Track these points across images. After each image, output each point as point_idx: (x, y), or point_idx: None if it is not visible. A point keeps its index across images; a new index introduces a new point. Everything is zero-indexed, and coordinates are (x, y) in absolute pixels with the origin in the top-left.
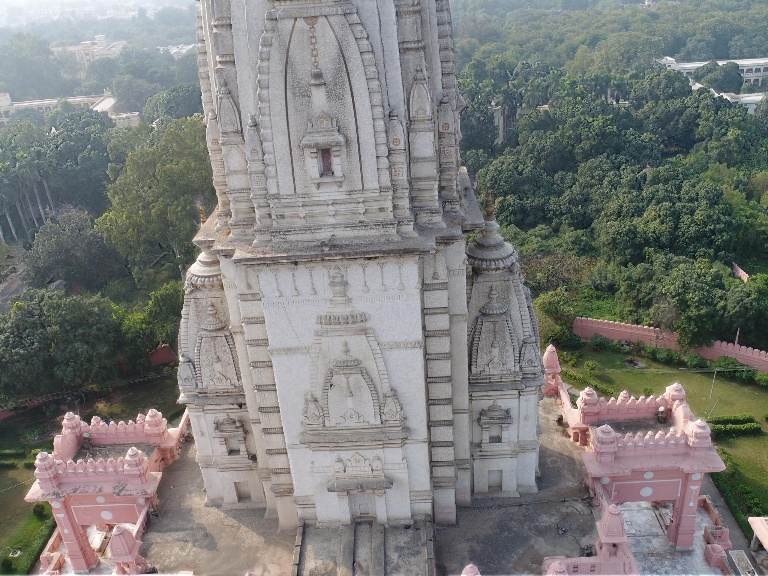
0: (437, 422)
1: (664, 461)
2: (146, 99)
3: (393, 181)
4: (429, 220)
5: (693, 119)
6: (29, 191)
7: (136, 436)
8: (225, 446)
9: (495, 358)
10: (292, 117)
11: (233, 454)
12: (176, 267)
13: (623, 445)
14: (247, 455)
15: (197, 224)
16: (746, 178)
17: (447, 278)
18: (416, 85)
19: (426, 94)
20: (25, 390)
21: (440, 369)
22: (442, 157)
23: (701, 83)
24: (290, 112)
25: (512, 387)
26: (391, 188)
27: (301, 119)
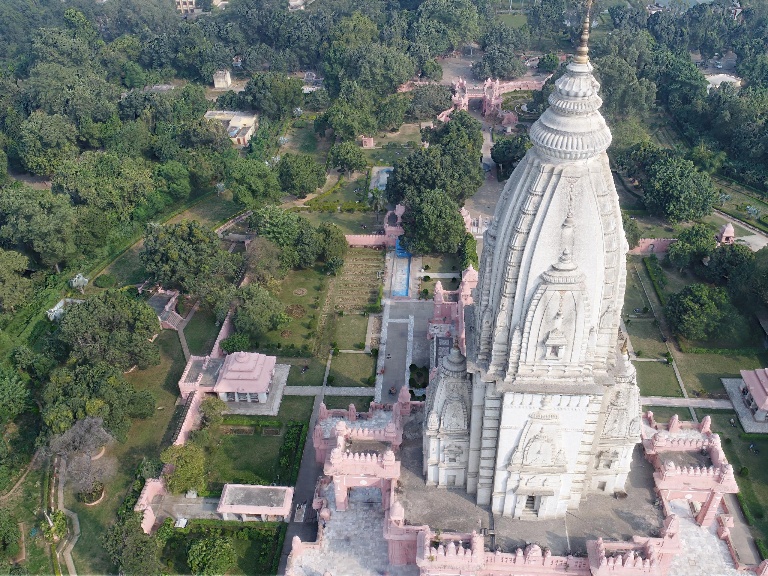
0: None
1: None
2: None
3: None
4: None
5: None
6: None
7: None
8: None
9: None
10: None
11: None
12: None
13: None
14: None
15: None
16: None
17: None
18: None
19: None
20: None
21: None
22: None
23: None
24: None
25: None
26: None
27: None
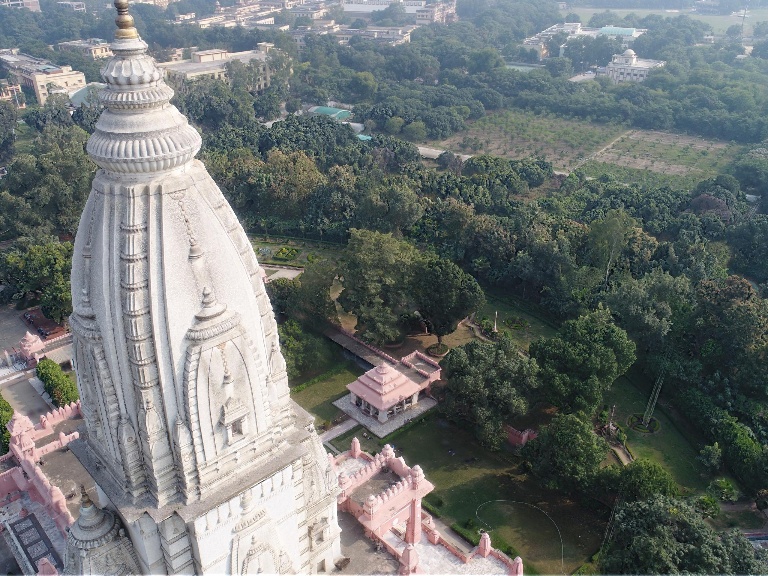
0: None
1: None
2: None
3: None
4: None
5: None
6: None
7: None
8: None
9: None
10: None
11: None
12: None
13: None
14: None
15: None
16: None
17: None
18: None
19: None
20: None
21: None
22: None
23: None
24: None
25: None
26: None
27: None
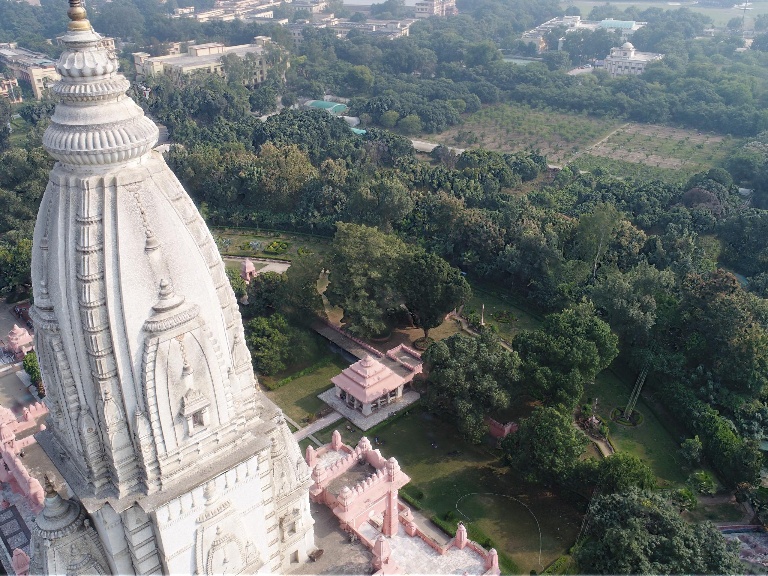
0: None
1: None
2: None
3: None
4: None
5: None
6: None
7: None
8: None
9: None
10: None
11: None
12: None
13: None
14: None
15: None
16: None
17: None
18: None
19: None
20: None
21: None
22: None
23: None
24: None
25: None
26: None
27: None
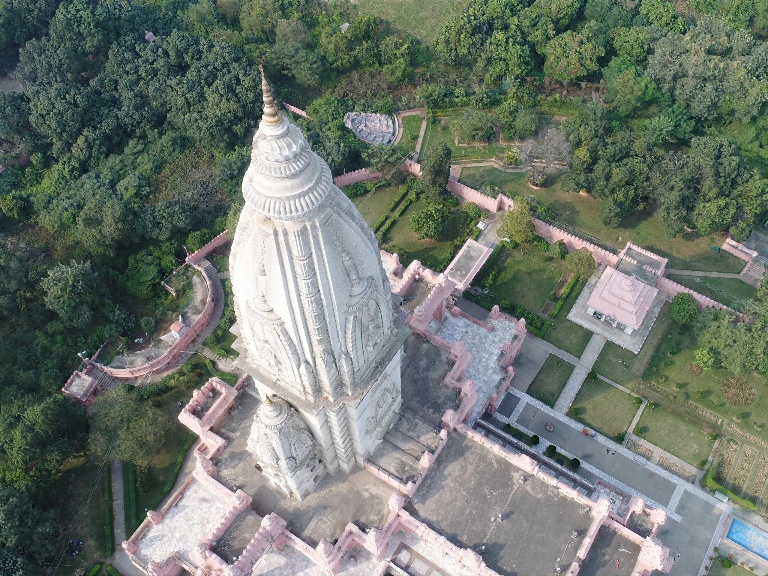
0: None
1: (438, 300)
2: None
3: None
4: None
5: None
6: None
7: None
8: None
9: None
10: None
11: (313, 470)
12: None
13: None
14: None
15: None
16: (212, 3)
17: None
18: None
19: None
20: None
21: None
22: None
23: None
24: None
25: None
26: None
27: None
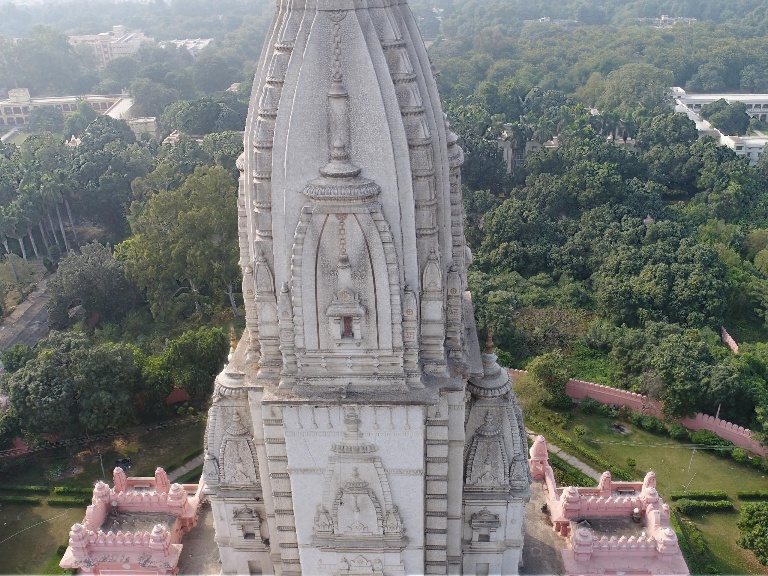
0: (433, 530)
1: (635, 563)
2: (164, 107)
3: (405, 342)
4: (435, 370)
5: (696, 168)
6: (51, 208)
7: (159, 506)
8: (242, 531)
9: (487, 473)
10: (320, 290)
11: (248, 538)
12: (192, 304)
13: (599, 546)
14: (261, 539)
15: (214, 263)
16: (743, 233)
17: (448, 417)
18: (429, 264)
19: (438, 271)
20: (50, 430)
21: (438, 488)
22: (449, 314)
23: (708, 121)
24: (319, 286)
25: (501, 498)
26: (403, 349)
27: (328, 292)
